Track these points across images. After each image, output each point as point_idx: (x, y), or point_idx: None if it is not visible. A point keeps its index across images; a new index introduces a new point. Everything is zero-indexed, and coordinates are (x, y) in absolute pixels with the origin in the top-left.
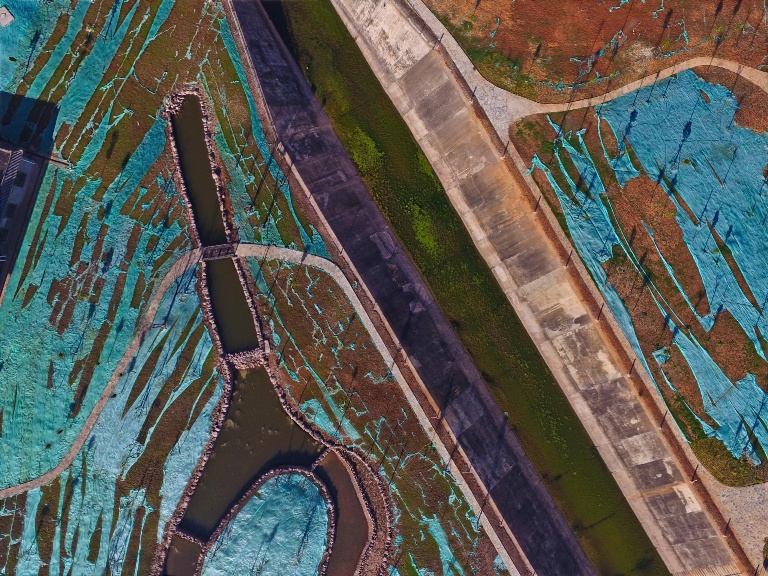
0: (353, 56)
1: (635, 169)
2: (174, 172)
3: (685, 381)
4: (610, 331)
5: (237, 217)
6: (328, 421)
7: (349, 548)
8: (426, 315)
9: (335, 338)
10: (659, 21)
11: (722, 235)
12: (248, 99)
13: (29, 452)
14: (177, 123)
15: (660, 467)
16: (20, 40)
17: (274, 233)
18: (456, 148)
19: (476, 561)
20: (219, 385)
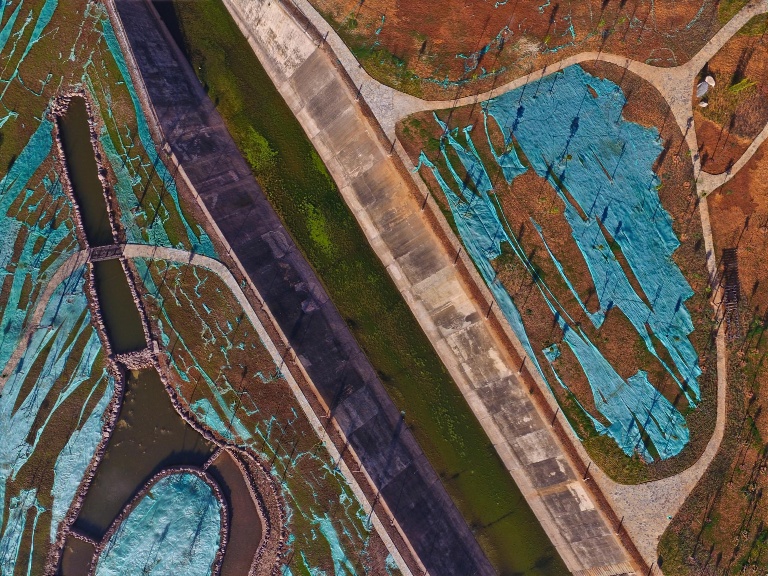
0: (245, 56)
1: (522, 165)
2: (61, 174)
3: (576, 378)
4: (500, 329)
5: (124, 218)
6: (219, 421)
7: (243, 547)
8: (319, 314)
9: (224, 338)
10: (545, 16)
11: (611, 231)
12: (133, 100)
13: None
14: (64, 125)
15: (553, 465)
16: None
17: (161, 233)
18: (346, 146)
19: (367, 560)
20: (110, 385)
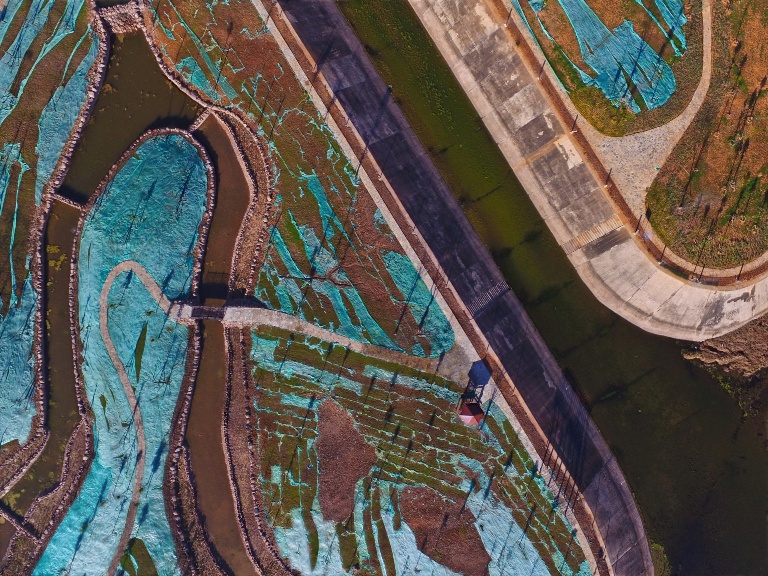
0: None
1: None
2: None
3: (562, 30)
4: None
5: None
6: (205, 79)
7: (231, 214)
8: None
9: None
10: None
11: None
12: None
13: None
14: None
15: (541, 123)
16: None
17: None
18: None
19: (356, 216)
20: (94, 43)
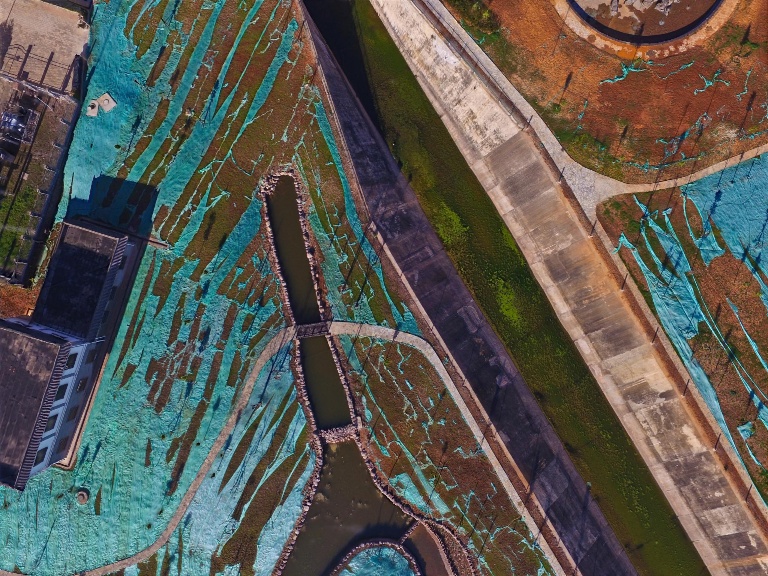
0: (438, 133)
1: (720, 248)
2: (269, 252)
3: None
4: (696, 406)
5: (330, 295)
6: (418, 495)
7: None
8: (512, 388)
9: (426, 414)
10: (743, 104)
11: None
12: (342, 180)
13: (127, 529)
14: (271, 203)
15: (744, 539)
16: (122, 125)
17: (366, 311)
18: (542, 225)
19: None
20: (311, 460)
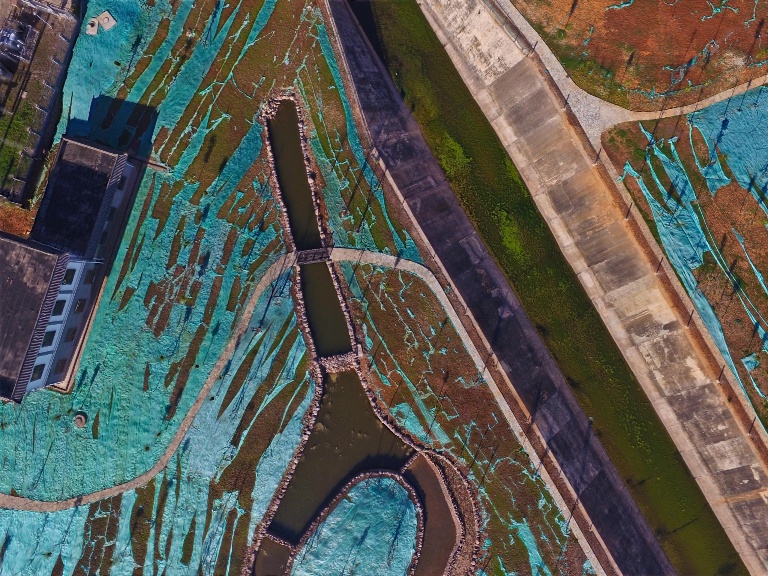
0: (442, 62)
1: (726, 177)
2: (270, 176)
3: None
4: (700, 337)
5: (331, 221)
6: (418, 425)
7: (437, 552)
8: (514, 320)
9: (427, 342)
10: (751, 31)
11: None
12: (344, 105)
13: (125, 454)
14: (272, 128)
15: (747, 473)
16: (122, 44)
17: (368, 238)
18: (546, 155)
19: (565, 565)
20: (311, 388)
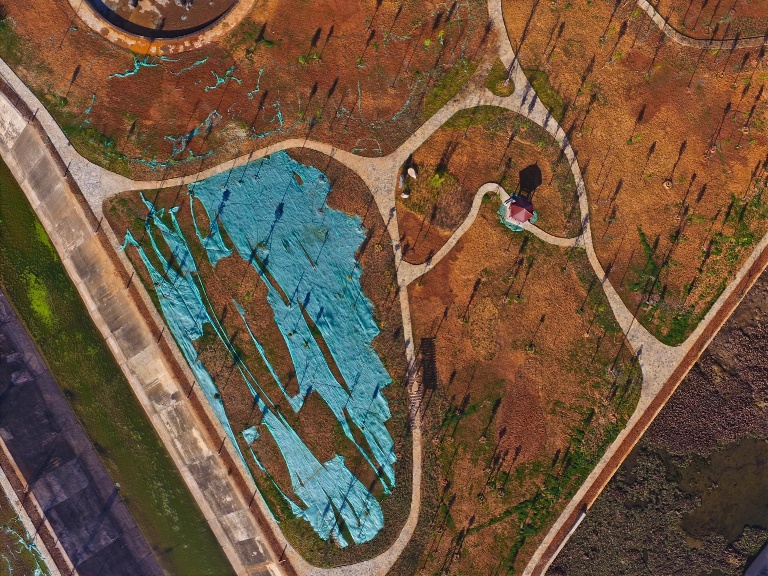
0: None
1: (226, 248)
2: None
3: (274, 461)
4: (200, 409)
5: None
6: None
7: None
8: (32, 385)
9: None
10: (254, 102)
11: (313, 316)
12: None
13: None
14: None
15: (254, 545)
16: None
17: None
18: (62, 220)
19: None
20: None
